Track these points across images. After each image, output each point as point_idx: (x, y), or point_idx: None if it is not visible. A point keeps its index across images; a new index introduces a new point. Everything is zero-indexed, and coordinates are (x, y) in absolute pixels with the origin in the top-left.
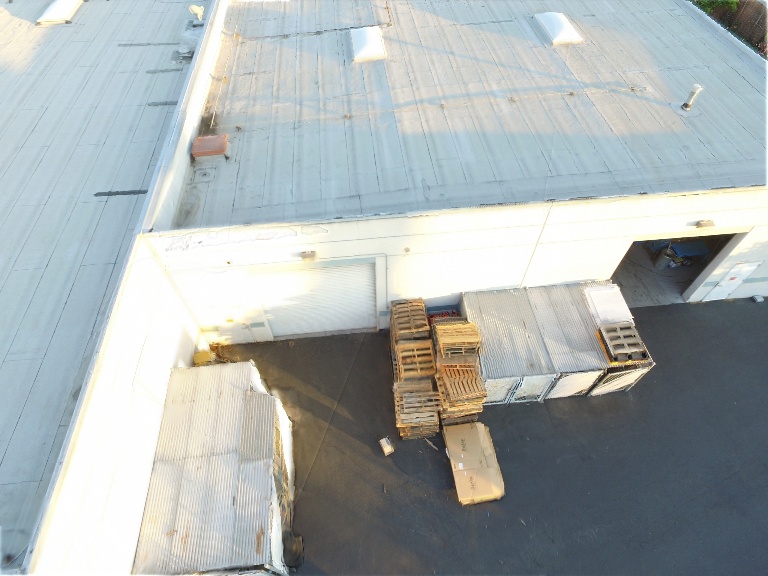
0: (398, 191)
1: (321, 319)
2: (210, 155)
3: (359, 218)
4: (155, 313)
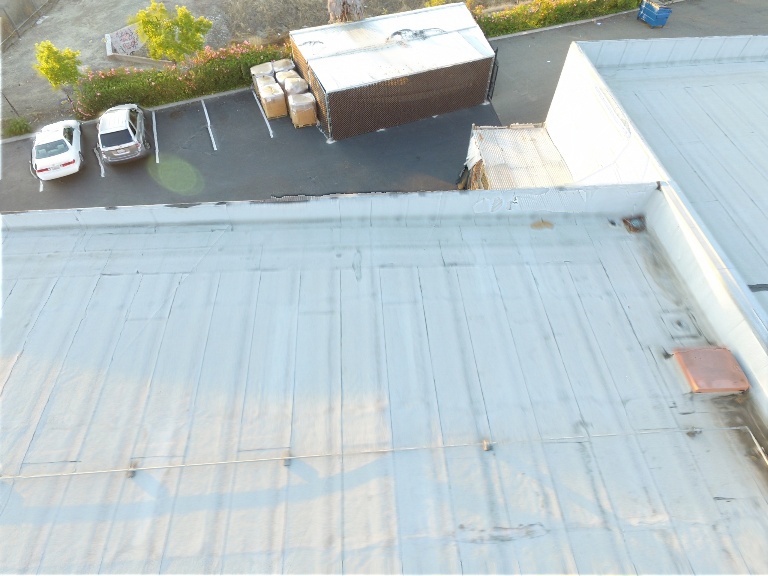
0: (394, 263)
1: None
2: None
3: None
4: None
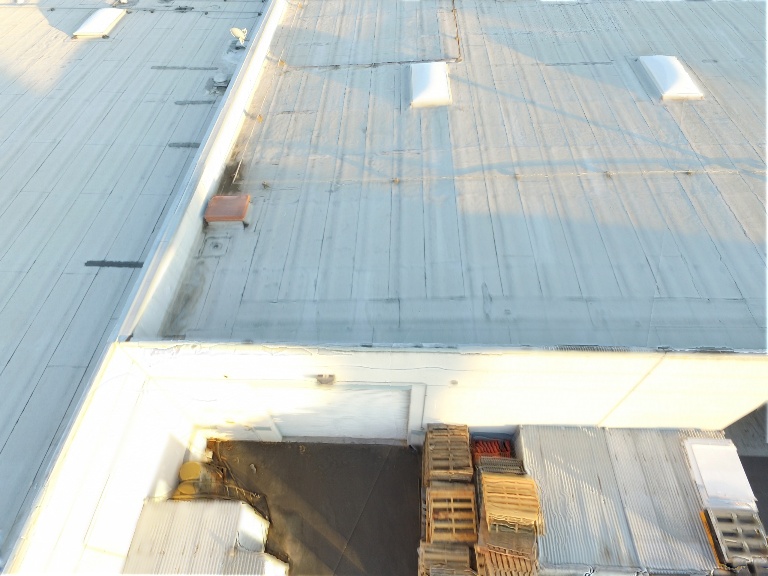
0: (450, 299)
1: (340, 427)
2: (226, 221)
3: (394, 348)
4: (123, 447)
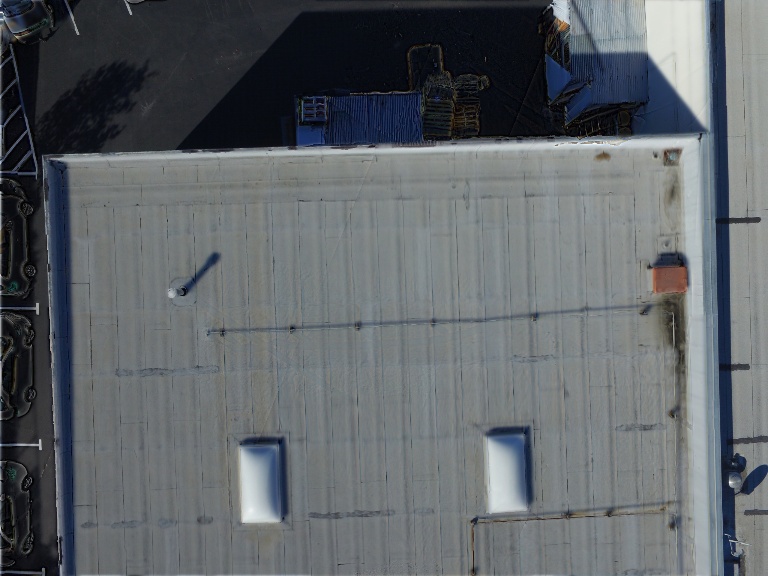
0: (492, 195)
1: None
2: None
3: (534, 138)
4: None
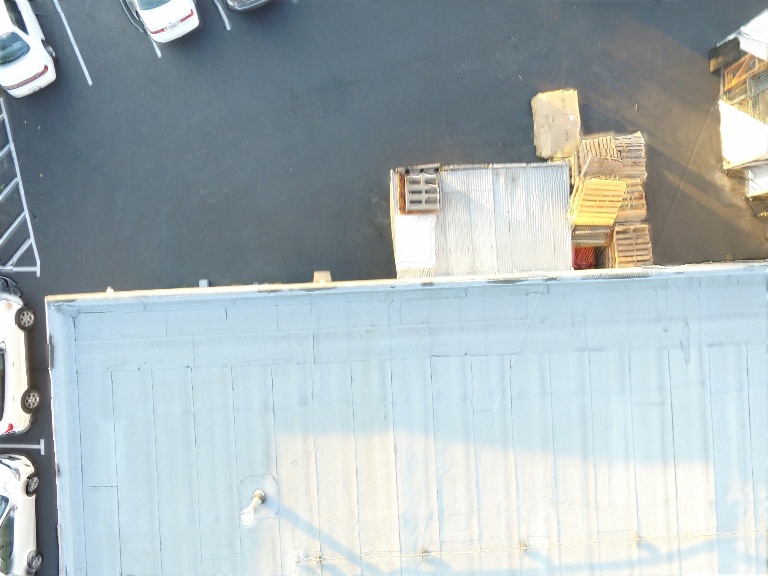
0: (724, 342)
1: None
2: None
3: None
4: None
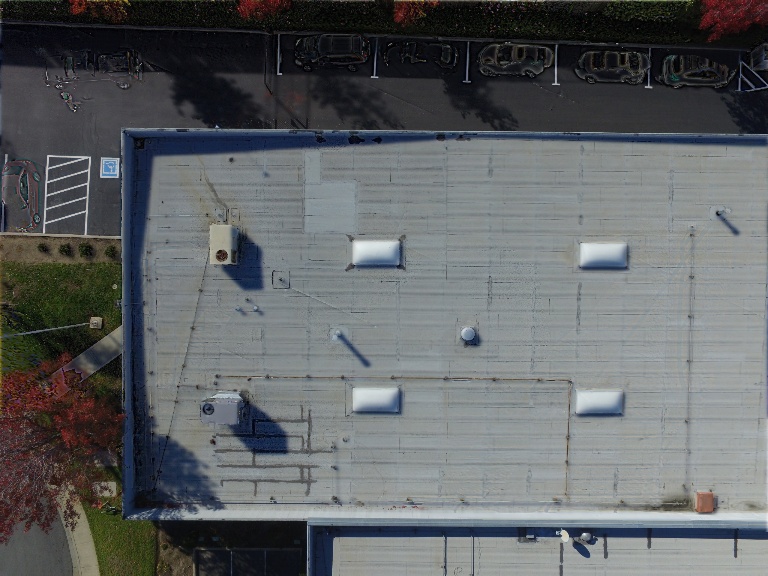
0: None
1: None
2: None
3: None
4: None
